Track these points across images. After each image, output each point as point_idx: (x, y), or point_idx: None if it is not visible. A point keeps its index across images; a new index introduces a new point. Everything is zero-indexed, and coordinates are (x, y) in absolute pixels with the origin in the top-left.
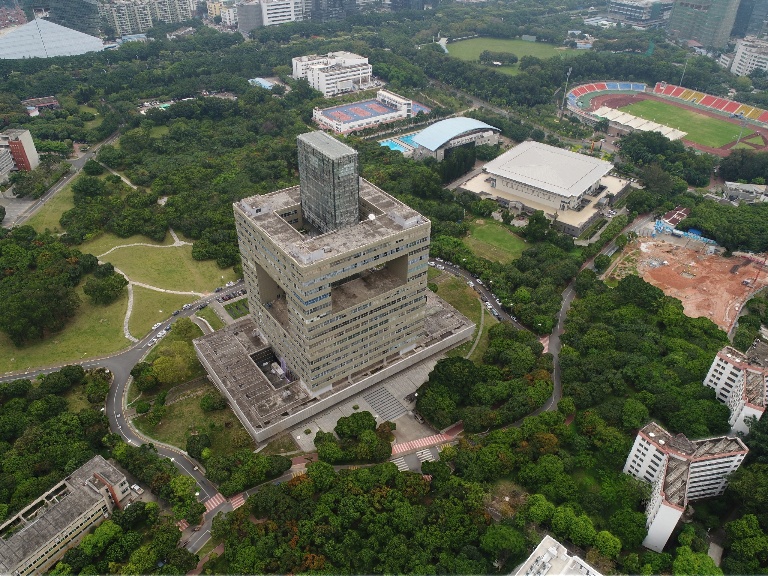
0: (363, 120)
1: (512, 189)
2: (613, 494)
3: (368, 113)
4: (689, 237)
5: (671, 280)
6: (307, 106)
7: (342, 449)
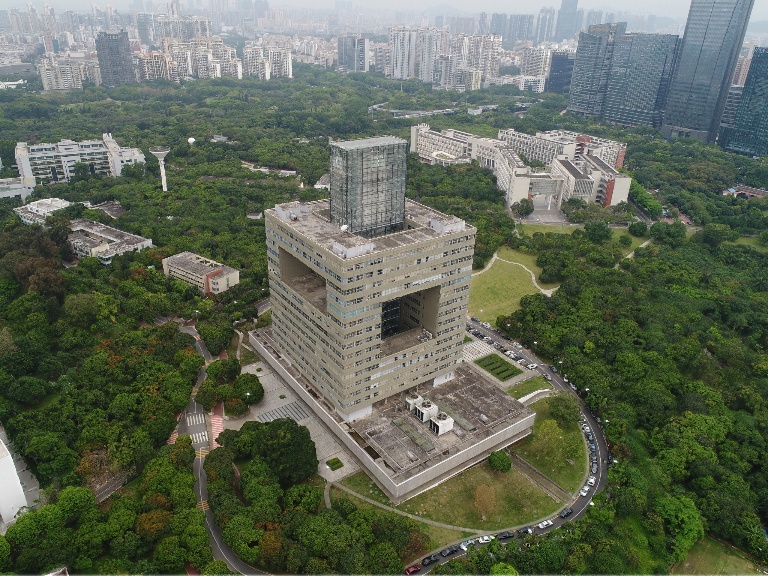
0: None
1: None
2: None
3: None
4: None
5: None
6: None
7: None
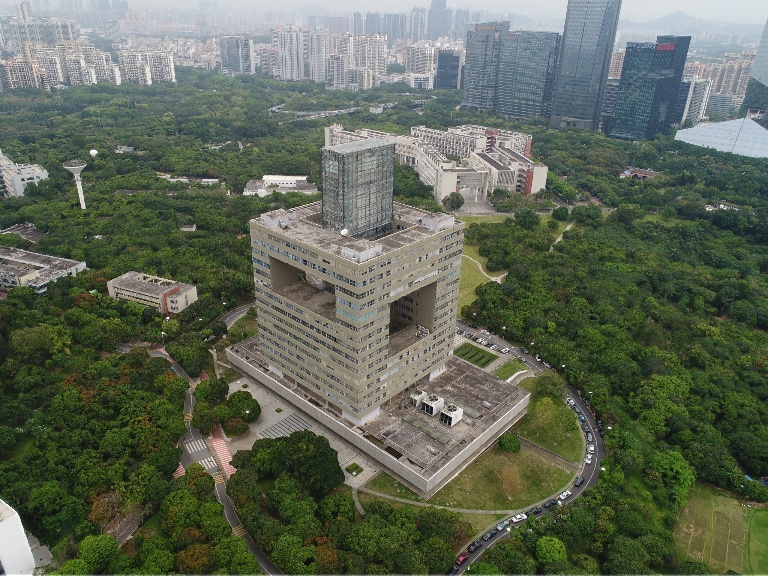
0: None
1: None
2: None
3: None
4: None
5: None
6: None
7: (207, 397)
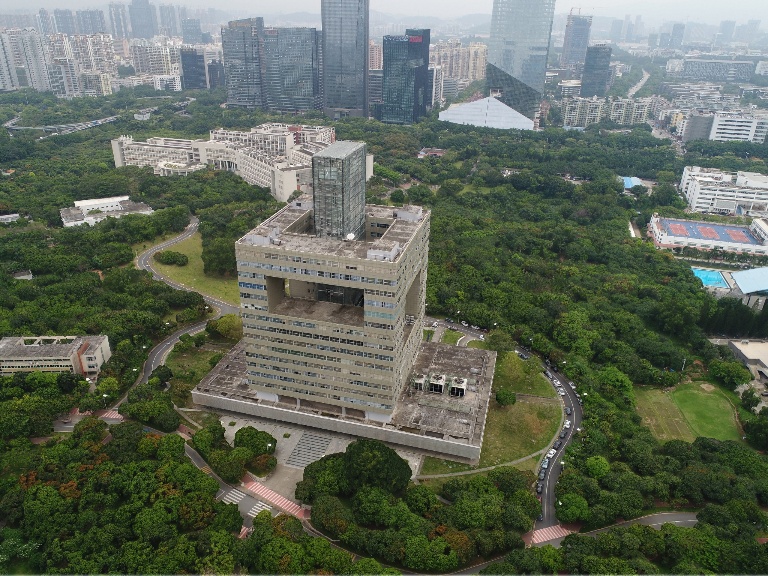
0: (698, 239)
1: None
2: None
3: (716, 236)
4: None
5: None
6: (651, 211)
7: (212, 445)
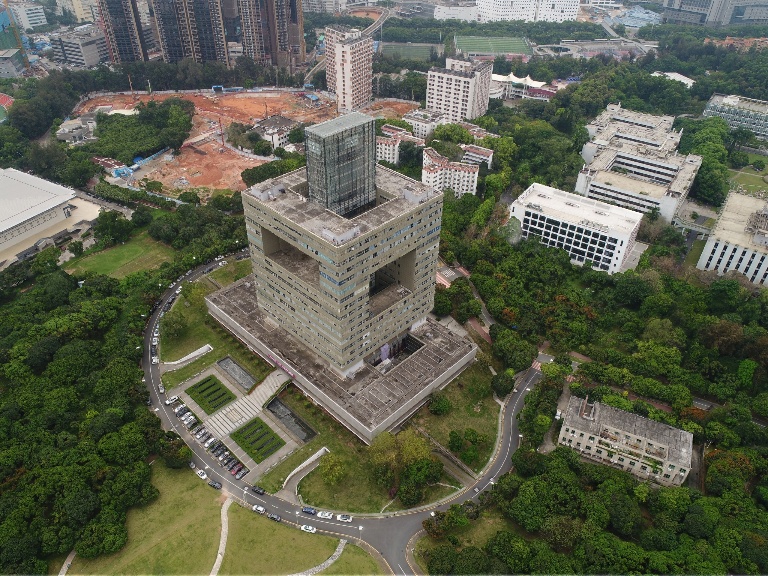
0: None
1: (8, 241)
2: (454, 202)
3: None
4: (141, 164)
5: (211, 178)
6: None
7: None
